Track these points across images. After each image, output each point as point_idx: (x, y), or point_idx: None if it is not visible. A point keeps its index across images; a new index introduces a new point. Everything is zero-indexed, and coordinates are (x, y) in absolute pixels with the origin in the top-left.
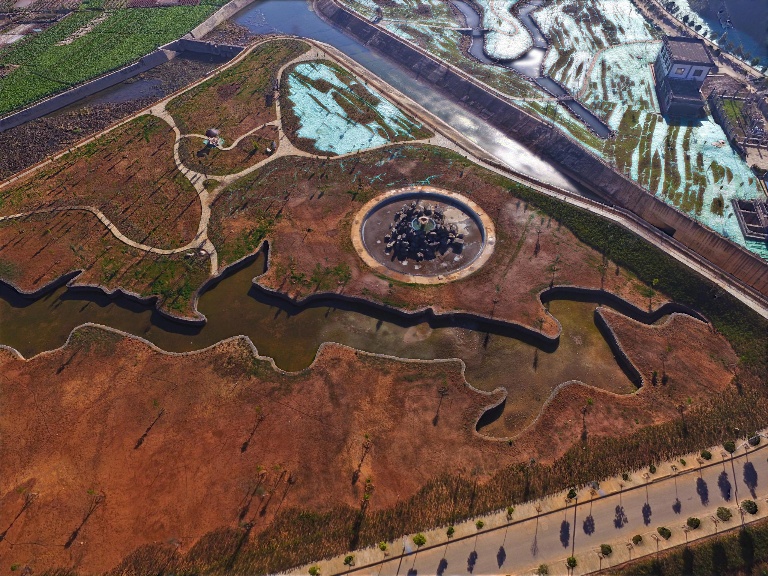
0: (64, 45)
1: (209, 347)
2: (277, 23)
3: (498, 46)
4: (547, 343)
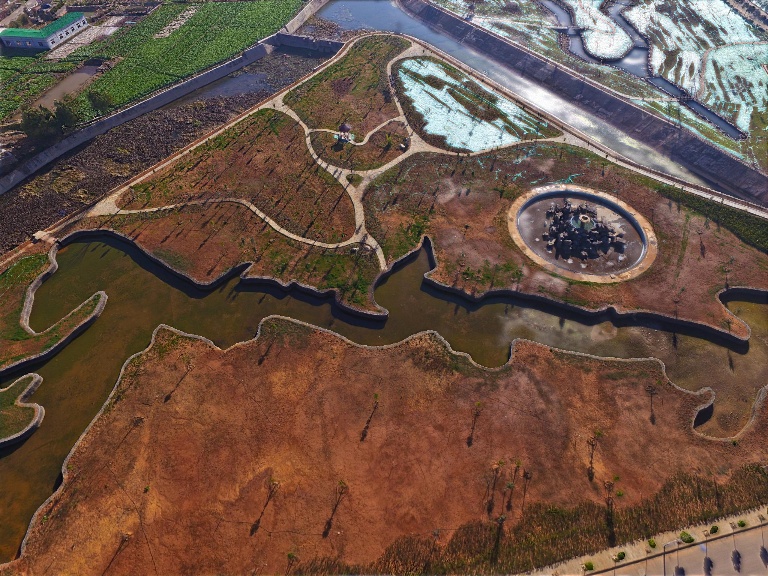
0: (162, 38)
1: (402, 341)
2: (365, 19)
3: (599, 45)
4: (737, 344)
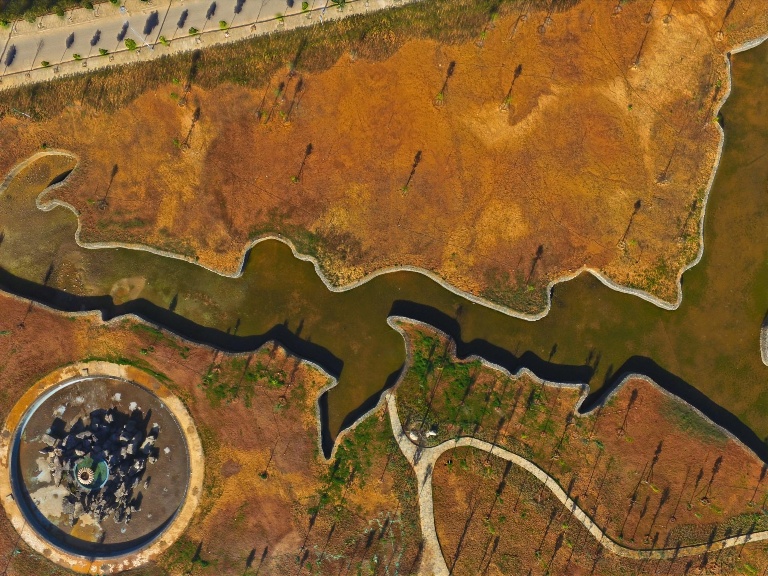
0: None
1: (372, 276)
2: None
3: None
4: None
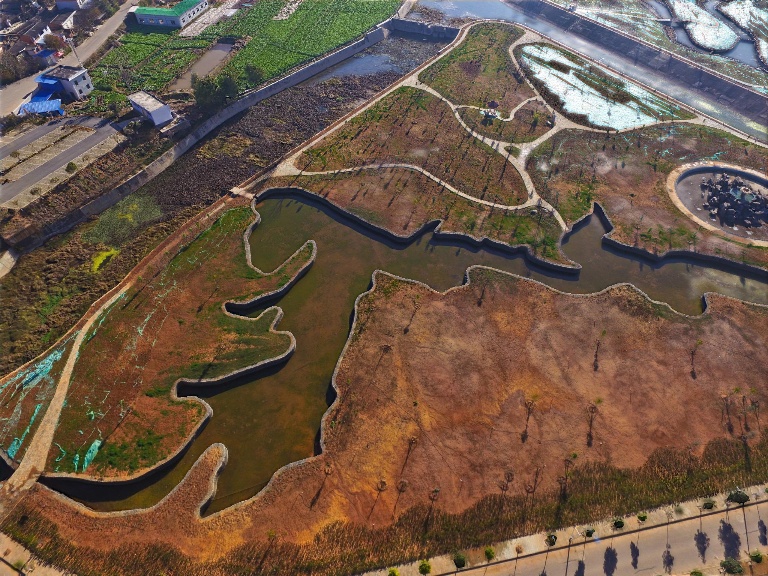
0: (283, 20)
1: (602, 291)
2: (466, 8)
3: (707, 37)
4: None
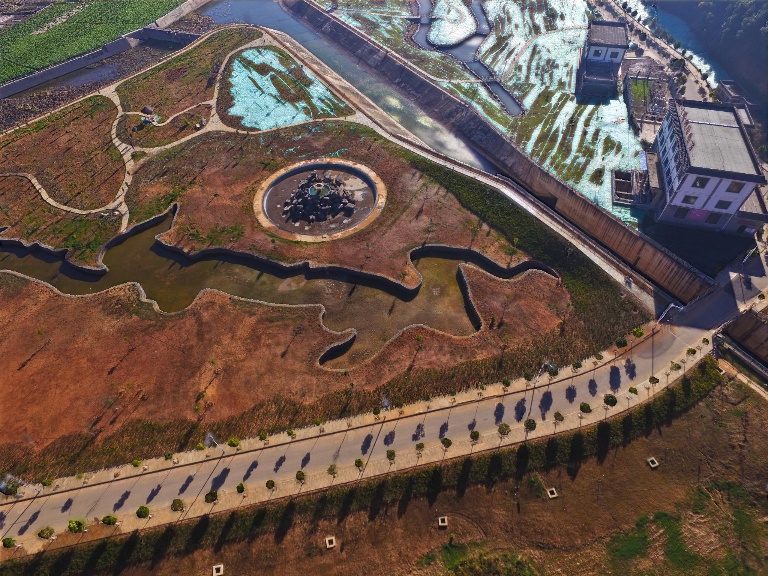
0: (38, 34)
1: (103, 291)
2: (241, 13)
3: (440, 33)
4: (407, 293)
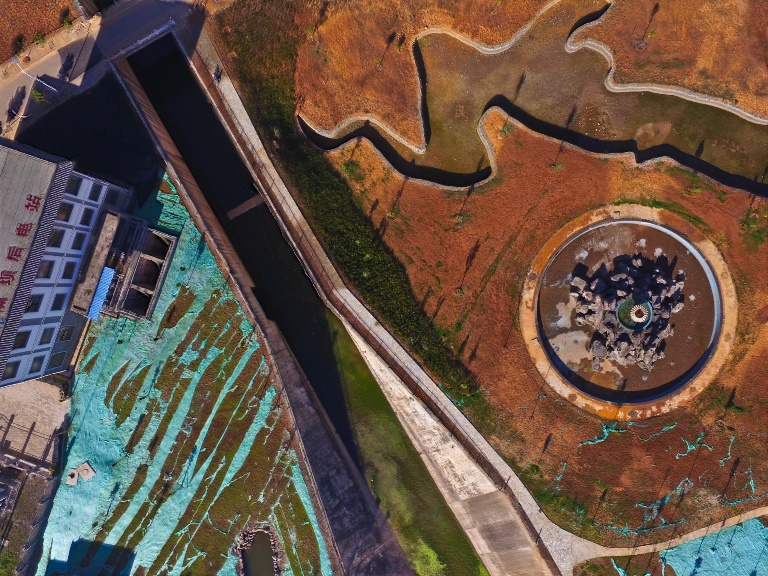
0: None
1: None
2: None
3: None
4: None
